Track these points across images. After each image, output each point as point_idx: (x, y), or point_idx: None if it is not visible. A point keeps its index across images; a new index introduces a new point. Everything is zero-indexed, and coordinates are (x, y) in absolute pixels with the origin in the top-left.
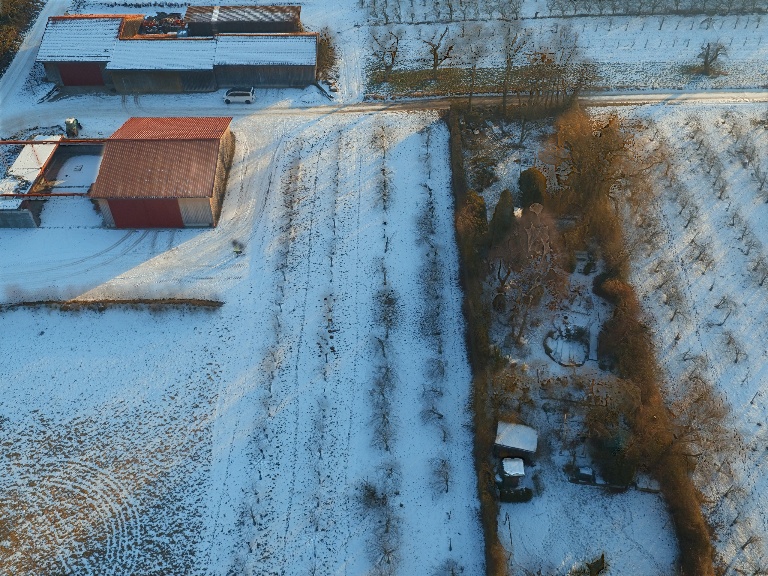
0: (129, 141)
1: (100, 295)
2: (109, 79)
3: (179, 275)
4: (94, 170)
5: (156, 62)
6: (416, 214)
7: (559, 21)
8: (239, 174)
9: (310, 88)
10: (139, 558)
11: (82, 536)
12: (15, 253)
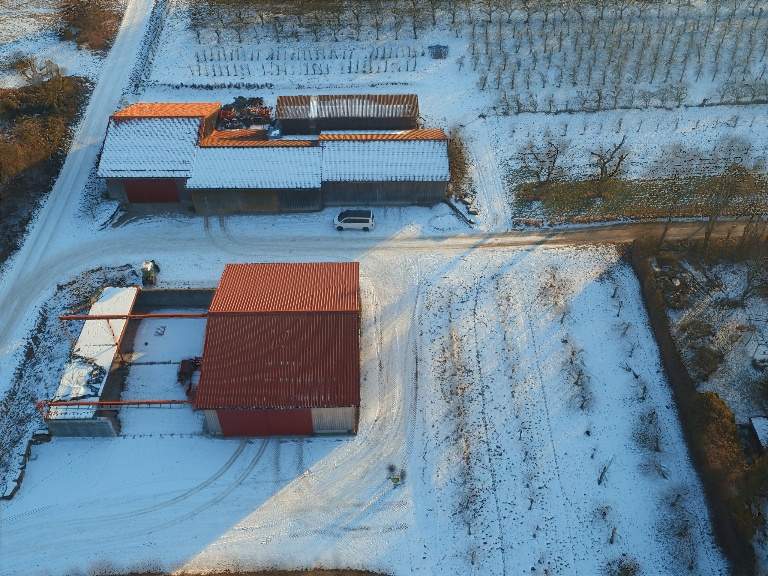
0: (237, 315)
1: (217, 562)
2: (186, 195)
3: (321, 523)
4: (181, 334)
5: (248, 178)
6: (627, 417)
7: (733, 110)
8: (373, 344)
9: (441, 208)
10: None
11: None
12: (91, 481)
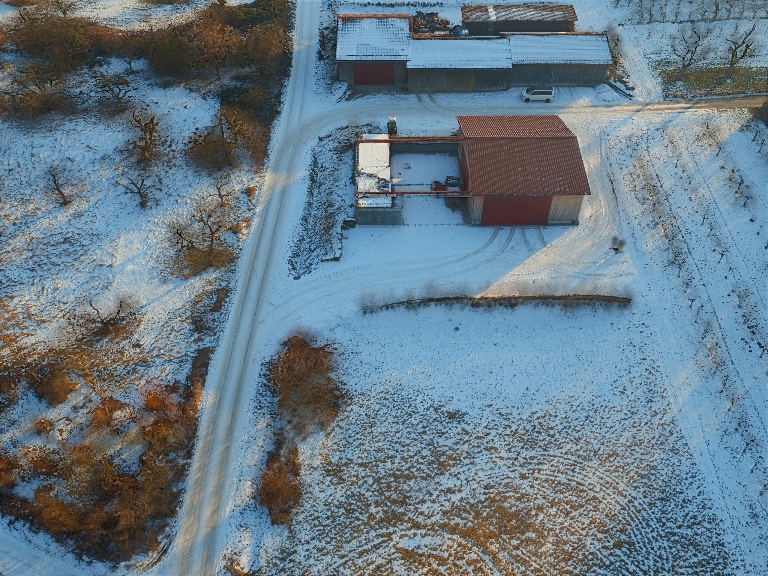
0: (487, 139)
1: (503, 291)
2: (400, 78)
3: (570, 272)
4: (423, 168)
5: (455, 61)
6: None
7: None
8: None
9: (603, 87)
10: (671, 549)
11: (603, 528)
12: (393, 250)
